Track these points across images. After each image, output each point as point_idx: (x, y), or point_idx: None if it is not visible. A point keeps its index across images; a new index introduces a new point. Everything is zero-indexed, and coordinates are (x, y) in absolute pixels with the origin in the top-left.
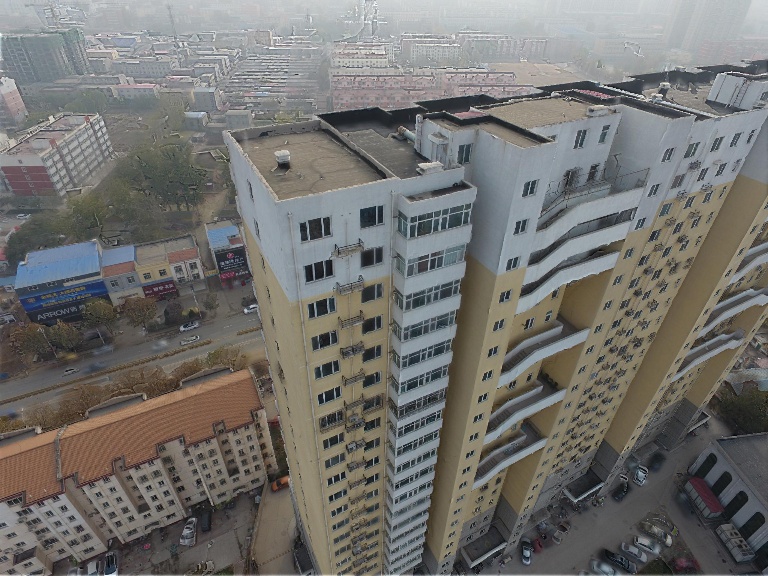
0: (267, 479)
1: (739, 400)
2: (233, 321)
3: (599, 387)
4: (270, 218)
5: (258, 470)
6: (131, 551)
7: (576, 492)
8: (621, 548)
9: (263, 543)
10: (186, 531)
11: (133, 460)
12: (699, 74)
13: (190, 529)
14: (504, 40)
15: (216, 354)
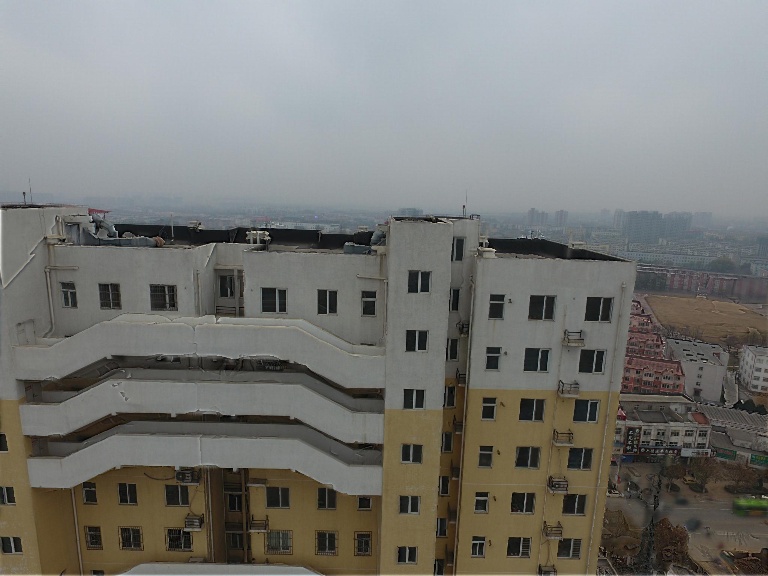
0: None
1: None
2: None
3: None
4: None
5: None
6: None
7: None
8: None
9: None
10: None
11: None
12: (219, 232)
13: None
14: (675, 274)
15: None
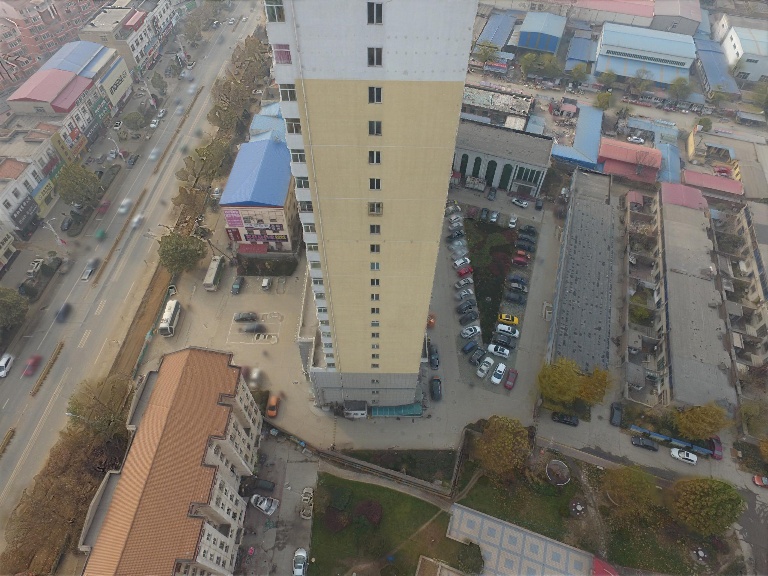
0: (262, 416)
1: None
2: (1, 395)
3: None
4: (447, 10)
5: (256, 413)
6: (244, 570)
7: None
8: (451, 230)
9: (316, 439)
10: (263, 505)
11: (203, 493)
12: None
13: (264, 501)
14: None
15: (77, 406)
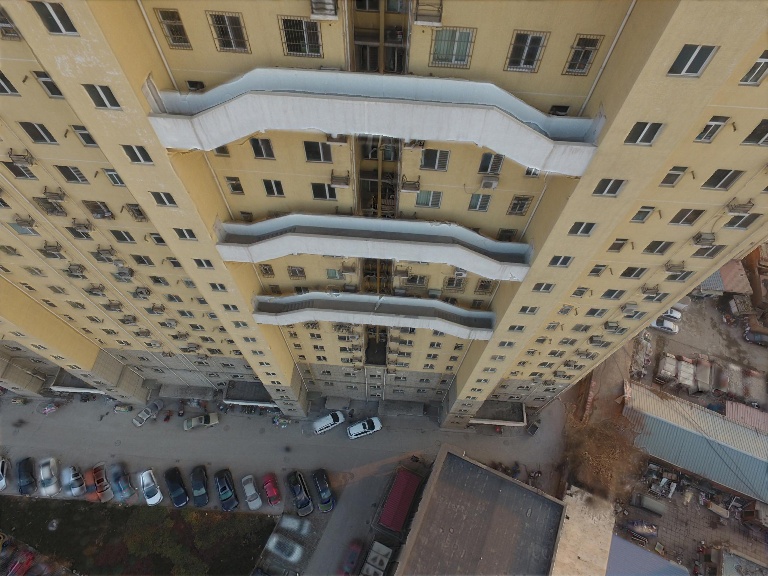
0: None
1: (576, 430)
2: None
3: (85, 259)
4: None
5: None
6: None
7: (236, 394)
8: (242, 478)
9: None
10: None
11: None
12: None
13: None
14: None
15: None
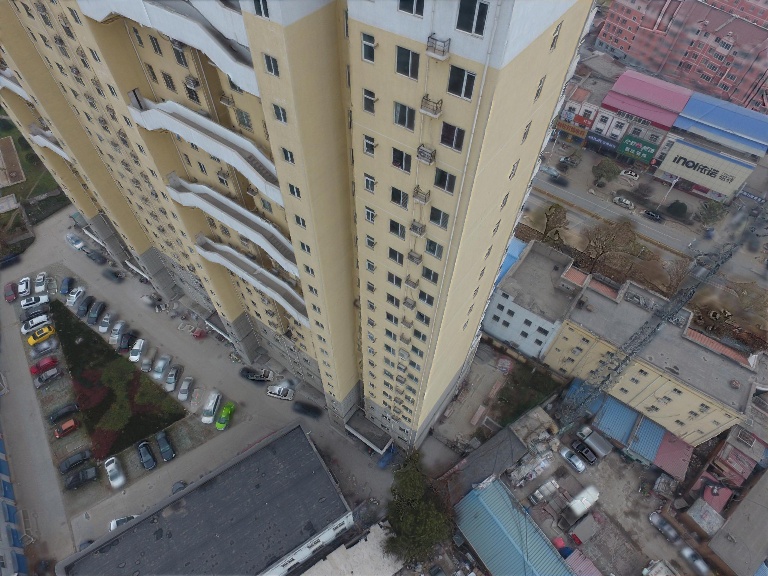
0: None
1: None
2: None
3: None
4: None
5: None
6: None
7: (215, 320)
8: None
9: None
10: None
11: None
12: None
13: None
14: None
15: None
